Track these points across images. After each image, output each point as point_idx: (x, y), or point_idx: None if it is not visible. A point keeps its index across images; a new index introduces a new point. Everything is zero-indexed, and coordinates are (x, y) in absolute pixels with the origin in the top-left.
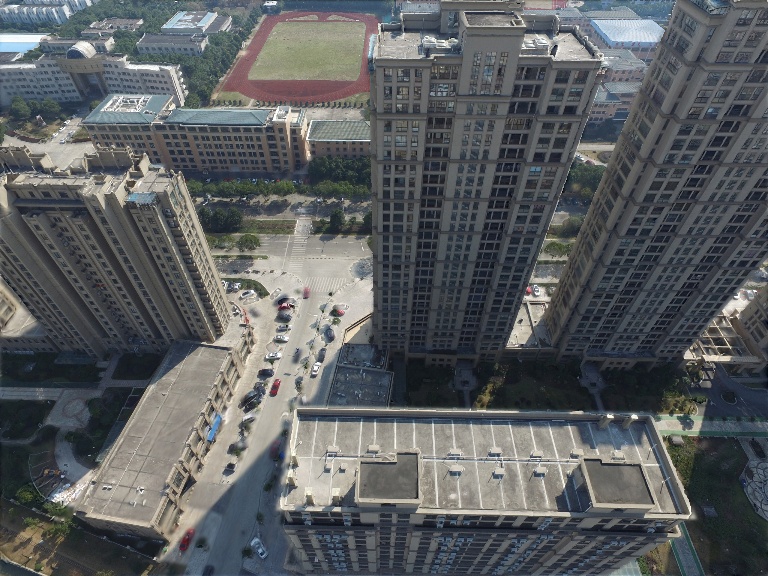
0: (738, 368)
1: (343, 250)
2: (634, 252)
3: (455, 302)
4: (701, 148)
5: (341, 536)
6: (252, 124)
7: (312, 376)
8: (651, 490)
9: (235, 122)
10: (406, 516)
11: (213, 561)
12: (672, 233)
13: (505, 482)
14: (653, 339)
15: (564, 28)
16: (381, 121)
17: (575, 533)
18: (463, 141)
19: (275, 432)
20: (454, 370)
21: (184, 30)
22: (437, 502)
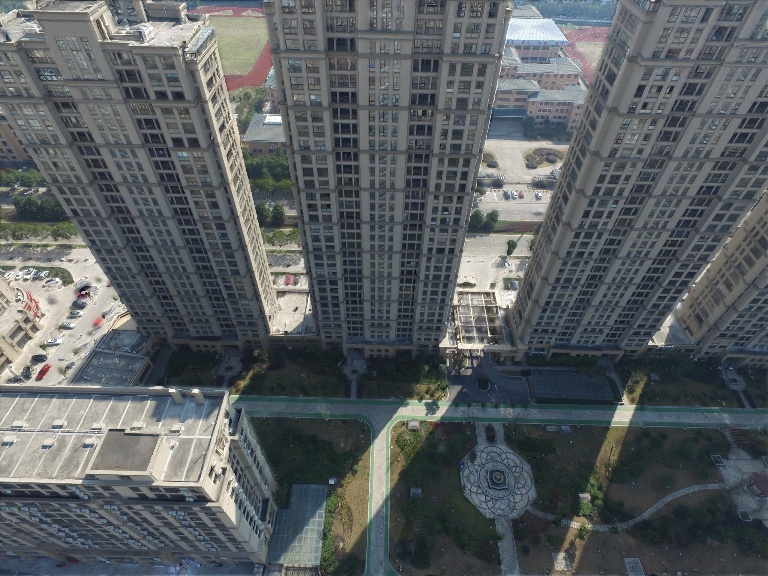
0: (499, 356)
1: None
2: (330, 238)
3: (190, 288)
4: (327, 135)
5: None
6: None
7: None
8: (152, 458)
9: None
10: None
11: None
12: (358, 220)
13: (50, 452)
14: (407, 327)
15: (196, 16)
16: (3, 104)
17: (120, 502)
18: (99, 125)
19: None
20: (221, 356)
21: None
22: None
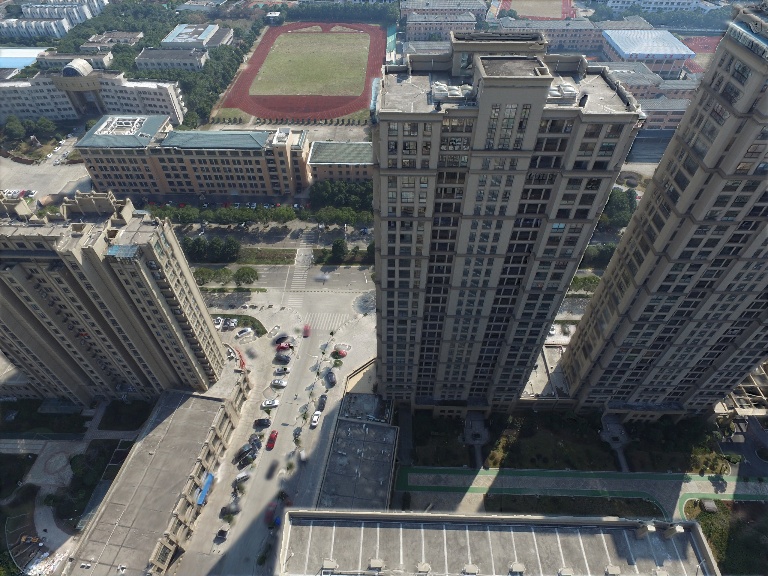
0: None
1: (345, 282)
2: (665, 308)
3: (466, 355)
4: (748, 204)
5: None
6: (251, 147)
7: (311, 427)
8: None
9: (233, 145)
10: None
11: None
12: (709, 289)
13: None
14: (681, 391)
15: (592, 69)
16: (385, 177)
17: None
18: (477, 196)
19: (271, 493)
20: (464, 422)
21: (184, 44)
22: None
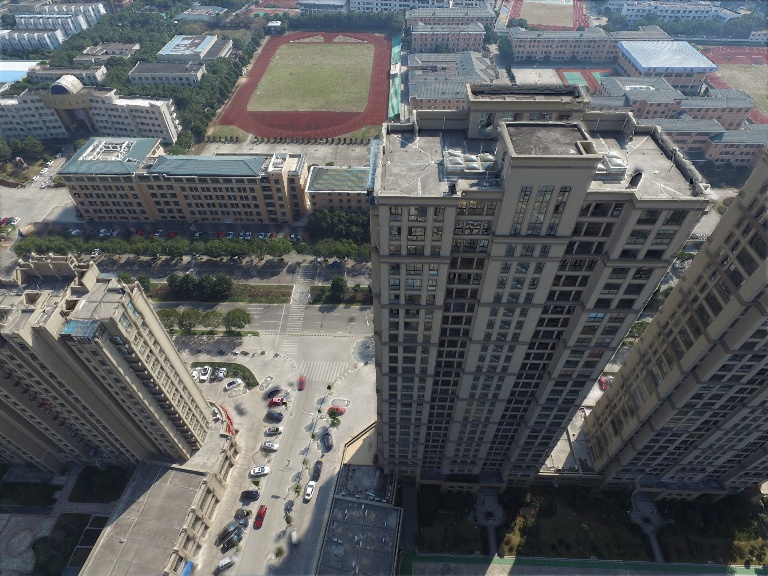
0: None
1: (345, 325)
2: (716, 396)
3: (479, 435)
4: None
5: None
6: (245, 175)
7: (305, 500)
8: None
9: (226, 172)
10: None
11: None
12: None
13: None
14: (723, 469)
15: (639, 129)
16: (386, 264)
17: None
18: (498, 283)
19: None
20: (476, 497)
21: (181, 56)
22: None
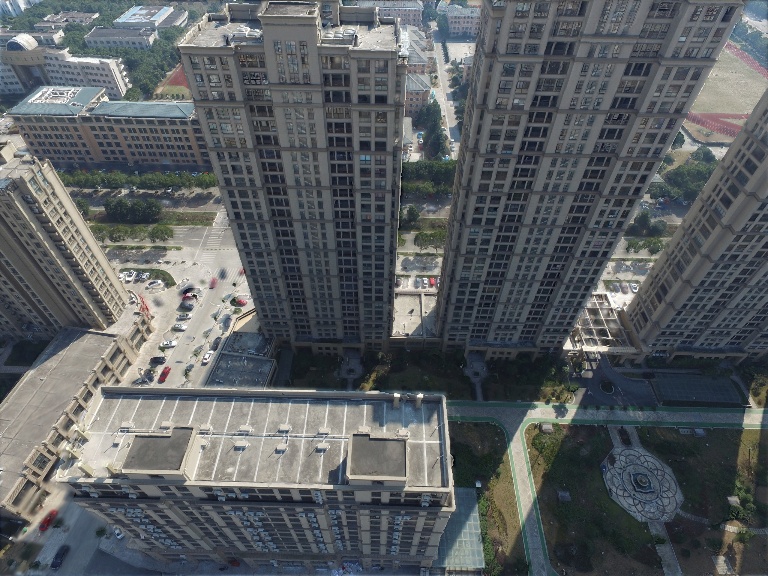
0: (619, 359)
1: None
2: (486, 241)
3: (328, 290)
4: (518, 138)
5: (134, 509)
6: (177, 117)
7: (203, 364)
8: (407, 463)
9: (160, 115)
10: (185, 489)
11: (70, 541)
12: (519, 223)
13: (285, 457)
14: (532, 329)
15: (387, 20)
16: (201, 108)
17: (354, 507)
18: (289, 129)
19: None
20: (341, 359)
21: (136, 24)
22: (213, 475)
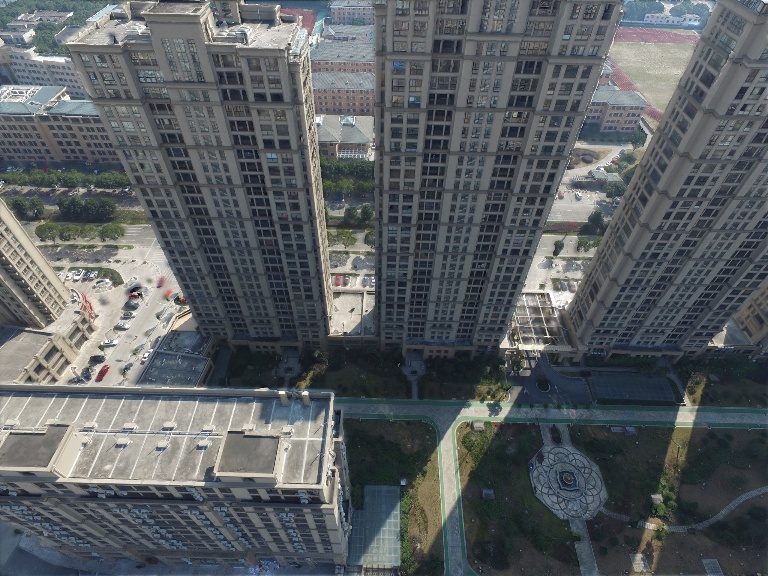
0: (557, 357)
1: None
2: (406, 240)
3: (257, 289)
4: (420, 136)
5: (19, 507)
6: None
7: (142, 362)
8: (276, 460)
9: None
10: (63, 486)
11: None
12: (436, 221)
13: (165, 454)
14: (468, 328)
15: (289, 18)
16: (100, 106)
17: (234, 504)
18: (191, 127)
19: None
20: (280, 357)
21: None
22: (89, 472)
